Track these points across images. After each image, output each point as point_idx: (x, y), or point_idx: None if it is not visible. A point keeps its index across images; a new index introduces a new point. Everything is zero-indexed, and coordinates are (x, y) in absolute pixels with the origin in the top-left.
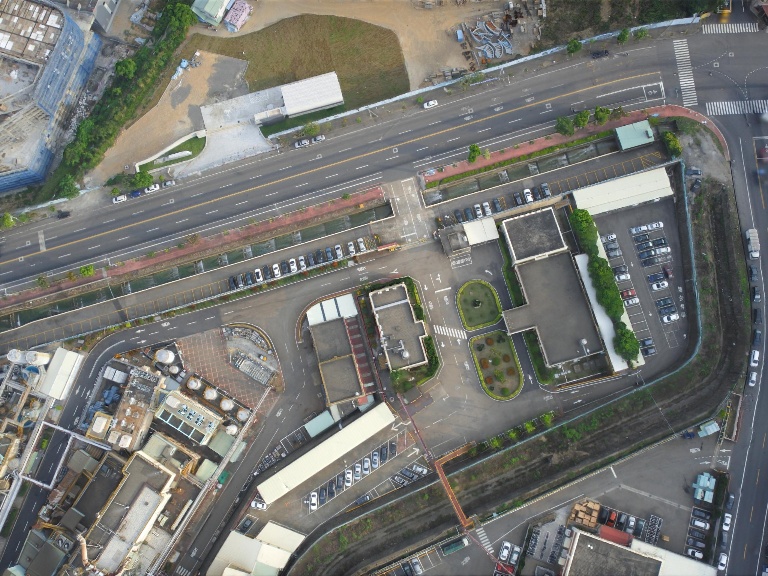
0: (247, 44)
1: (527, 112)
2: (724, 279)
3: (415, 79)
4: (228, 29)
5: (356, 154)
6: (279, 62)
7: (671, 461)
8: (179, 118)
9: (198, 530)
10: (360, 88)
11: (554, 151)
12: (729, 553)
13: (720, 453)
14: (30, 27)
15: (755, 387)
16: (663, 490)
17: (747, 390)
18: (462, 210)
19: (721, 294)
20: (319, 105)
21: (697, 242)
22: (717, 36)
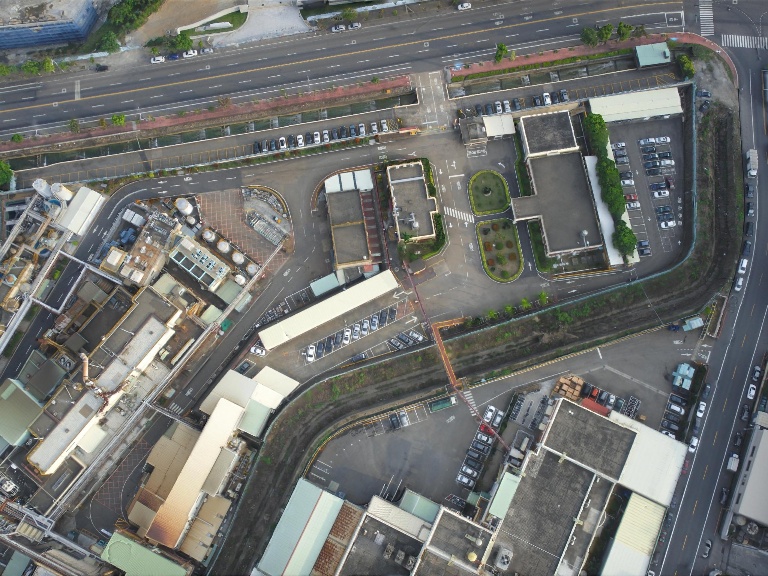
0: None
1: (554, 24)
2: (721, 195)
3: None
4: None
5: (389, 44)
6: None
7: (655, 349)
8: None
9: (195, 372)
10: None
11: (576, 62)
12: (700, 438)
13: (701, 347)
14: None
15: (740, 292)
16: (644, 375)
17: (732, 294)
18: (483, 105)
19: (717, 209)
20: None
21: (700, 157)
22: None
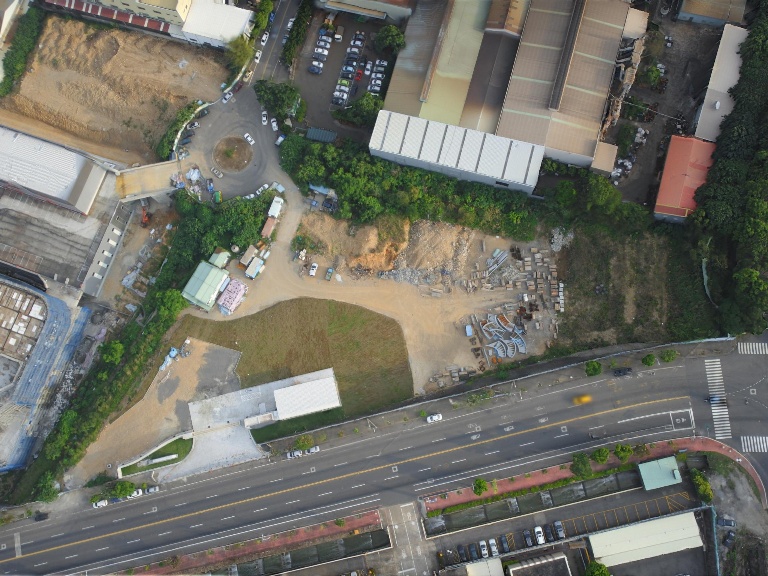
0: (240, 331)
1: (540, 435)
2: None
3: (419, 378)
4: (221, 311)
5: (352, 470)
6: (273, 354)
7: None
8: (166, 415)
9: None
10: (359, 388)
11: (569, 483)
12: None
13: None
14: (12, 318)
15: None
16: None
17: None
18: (466, 545)
19: None
20: (314, 411)
21: None
22: (754, 357)
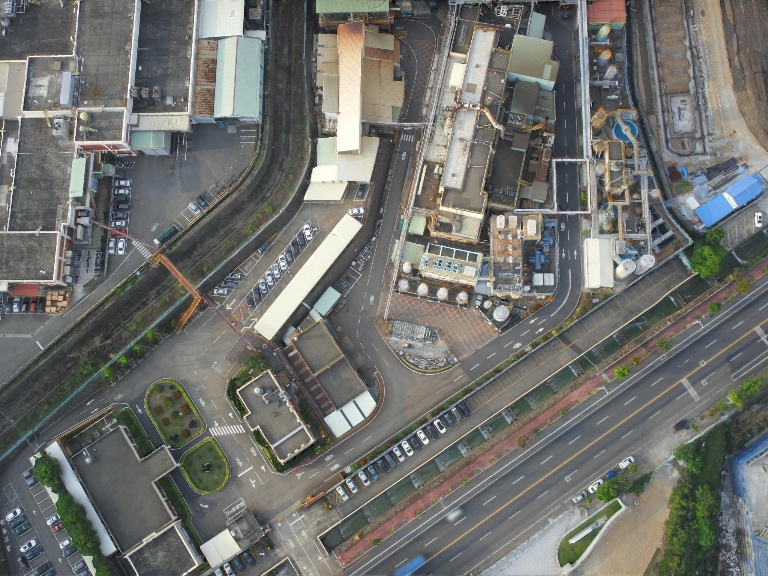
0: None
1: None
2: None
3: None
4: None
5: None
6: None
7: None
8: None
9: None
10: None
11: None
12: None
13: None
14: None
15: None
16: None
17: None
18: (248, 567)
19: None
20: None
21: None
22: None
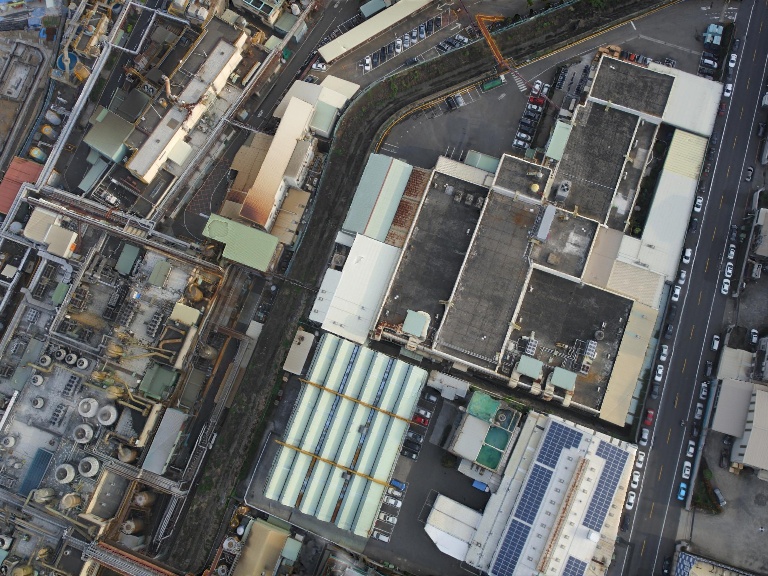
0: None
1: None
2: None
3: None
4: None
5: None
6: None
7: (684, 17)
8: None
9: (264, 96)
10: None
11: None
12: (734, 85)
13: (728, 10)
14: None
15: None
16: (677, 39)
17: None
18: None
19: None
20: None
21: None
22: None
